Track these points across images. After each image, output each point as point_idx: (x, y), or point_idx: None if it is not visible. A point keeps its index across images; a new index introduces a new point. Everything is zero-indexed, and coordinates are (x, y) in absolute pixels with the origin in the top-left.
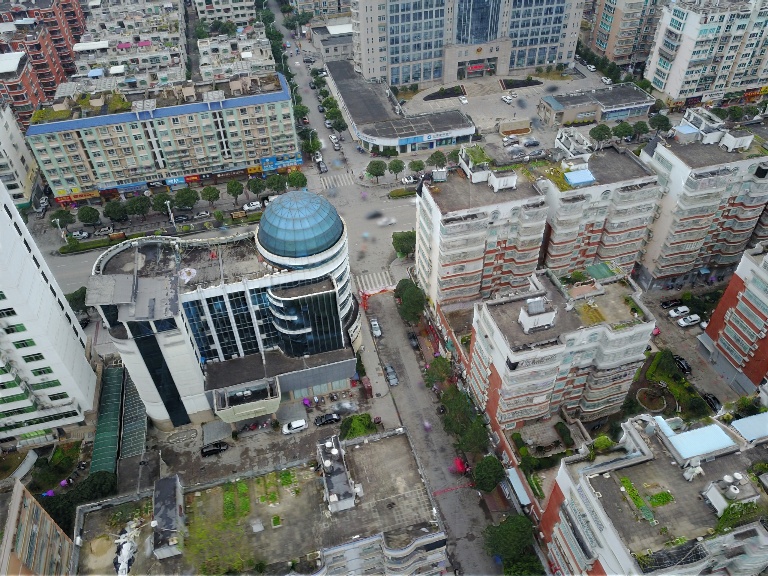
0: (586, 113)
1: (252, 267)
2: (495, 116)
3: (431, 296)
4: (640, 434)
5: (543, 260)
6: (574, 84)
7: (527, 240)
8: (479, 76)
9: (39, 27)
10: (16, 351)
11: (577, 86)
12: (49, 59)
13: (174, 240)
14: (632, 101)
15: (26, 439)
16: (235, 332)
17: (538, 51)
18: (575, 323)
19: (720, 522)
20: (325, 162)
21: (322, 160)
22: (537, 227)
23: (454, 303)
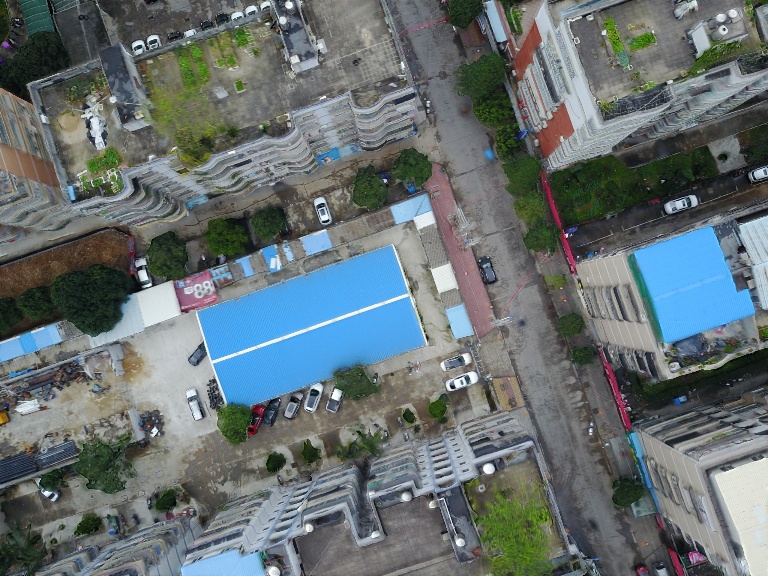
0: None
1: None
2: None
3: None
4: None
5: None
6: None
7: None
8: None
9: None
10: None
11: None
12: None
13: None
14: None
15: None
16: None
17: None
18: None
19: (696, 65)
20: None
21: None
22: None
23: None
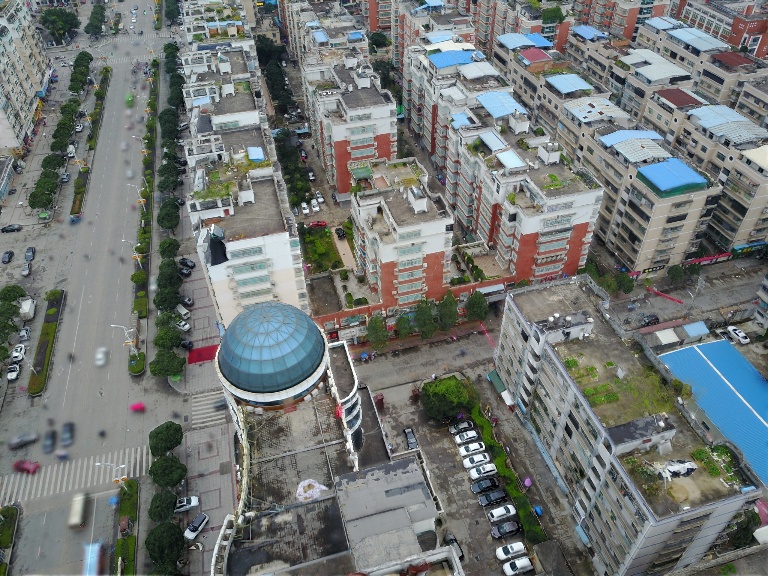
0: None
1: (305, 416)
2: None
3: None
4: None
5: None
6: None
7: None
8: None
9: None
10: None
11: None
12: None
13: (238, 517)
14: (0, 169)
15: None
16: None
17: None
18: None
19: (566, 160)
20: None
21: None
22: None
23: None
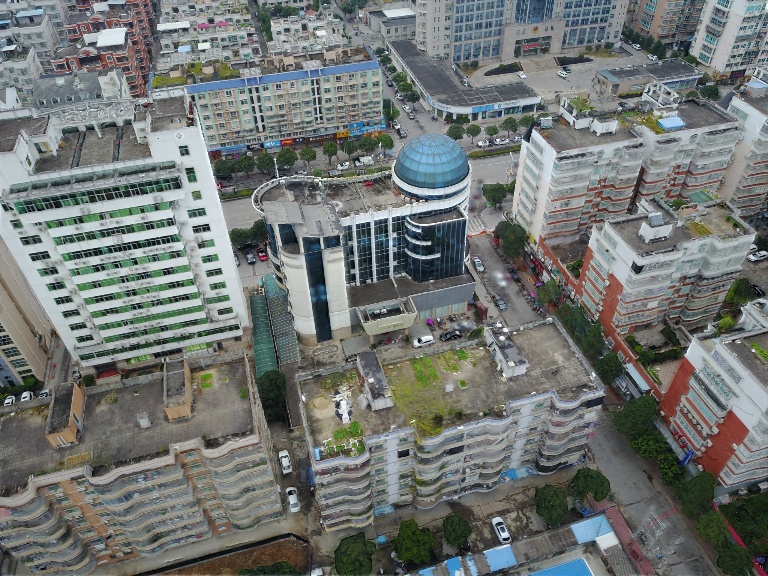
0: (639, 85)
1: (390, 200)
2: (553, 89)
3: (532, 233)
4: (759, 313)
5: (633, 200)
6: (622, 61)
7: (625, 178)
8: (533, 54)
9: (128, 7)
10: (202, 265)
11: (625, 63)
12: (138, 37)
13: (317, 178)
14: (682, 74)
15: (191, 352)
16: (373, 258)
17: (588, 31)
18: (687, 236)
19: None
20: (403, 129)
21: (400, 127)
22: (635, 166)
23: (556, 237)
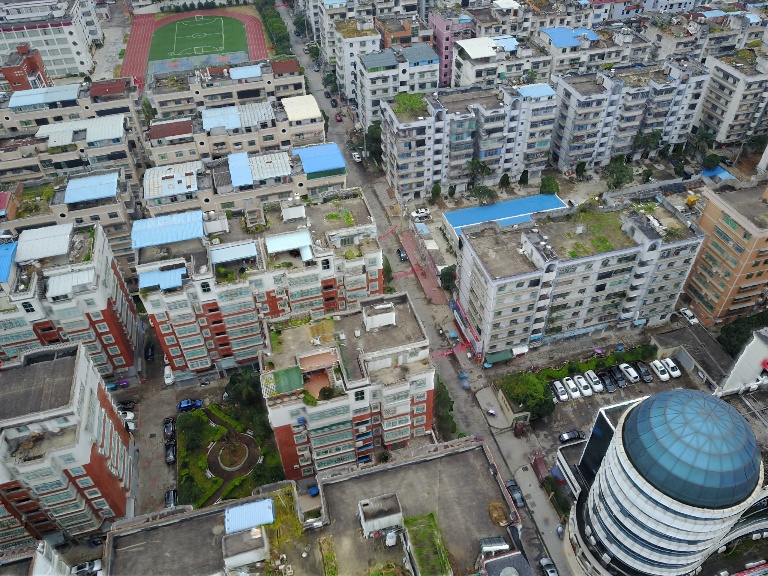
0: None
1: None
2: None
3: None
4: (327, 245)
5: None
6: None
7: None
8: None
9: None
10: None
11: None
12: None
13: None
14: None
15: None
16: None
17: None
18: (340, 325)
19: None
20: None
21: None
22: None
23: None
